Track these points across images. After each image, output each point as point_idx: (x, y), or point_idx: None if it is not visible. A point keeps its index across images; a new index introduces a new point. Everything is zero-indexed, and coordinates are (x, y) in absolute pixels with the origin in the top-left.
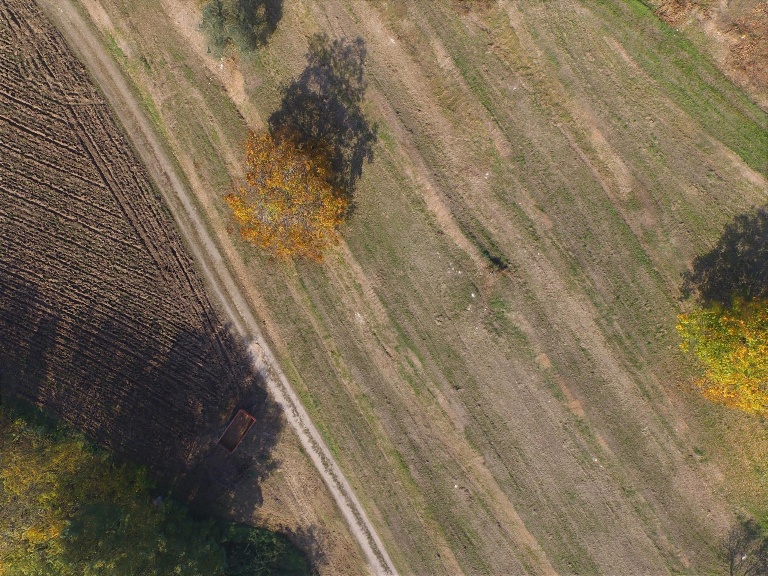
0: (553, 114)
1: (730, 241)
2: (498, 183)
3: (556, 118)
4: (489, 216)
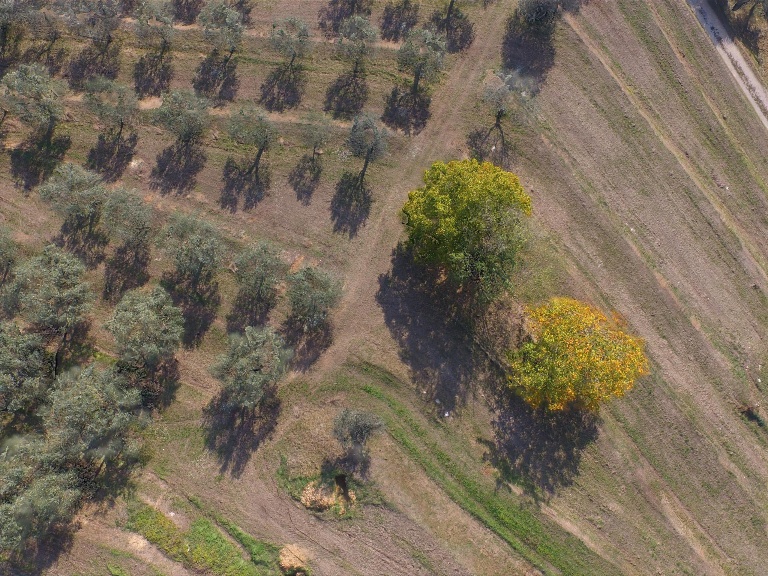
0: (736, 570)
1: (571, 460)
2: (765, 496)
3: (733, 567)
4: (764, 461)
